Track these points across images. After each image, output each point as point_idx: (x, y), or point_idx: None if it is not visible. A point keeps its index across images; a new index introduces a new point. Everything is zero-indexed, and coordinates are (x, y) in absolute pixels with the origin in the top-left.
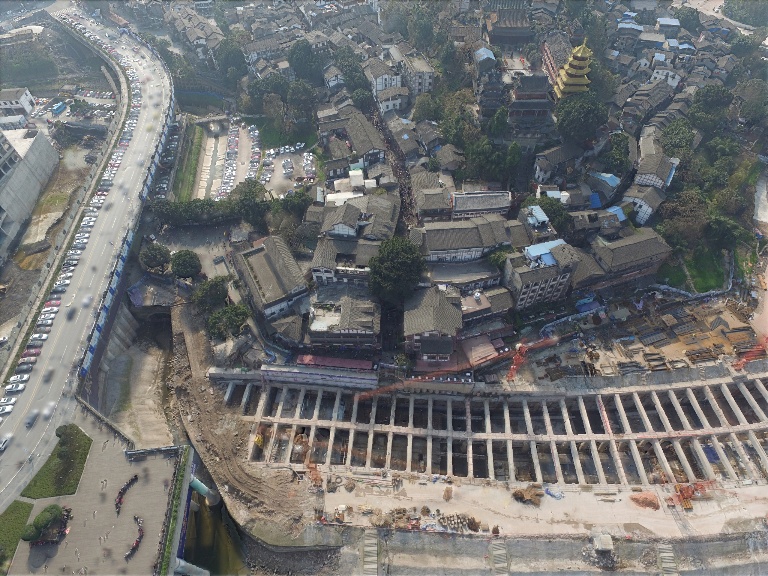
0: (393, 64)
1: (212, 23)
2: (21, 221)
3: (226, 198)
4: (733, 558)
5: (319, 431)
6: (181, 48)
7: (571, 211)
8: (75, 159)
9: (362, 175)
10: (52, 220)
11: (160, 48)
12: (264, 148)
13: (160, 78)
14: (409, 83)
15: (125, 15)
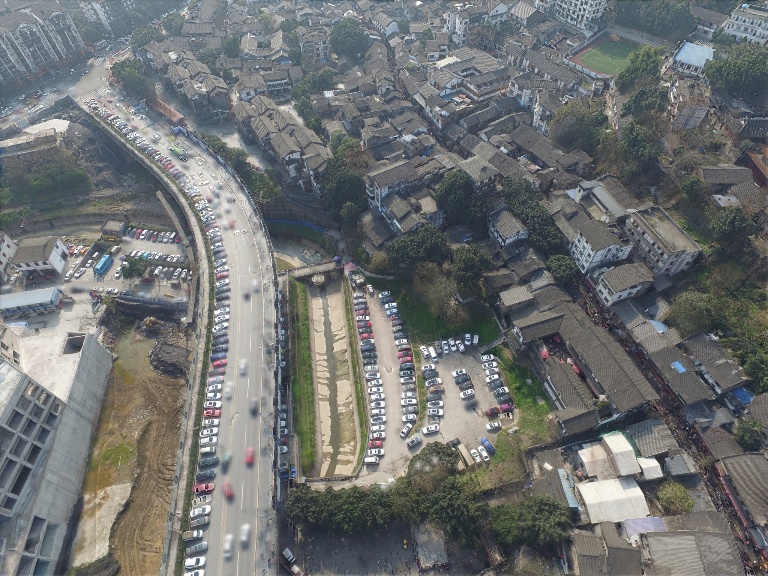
0: (610, 220)
1: (291, 112)
2: (68, 514)
3: (406, 486)
4: None
5: None
6: (260, 156)
7: None
8: (135, 360)
9: (633, 451)
10: (116, 504)
11: (235, 162)
12: (414, 339)
13: (245, 217)
14: (649, 258)
15: (176, 102)
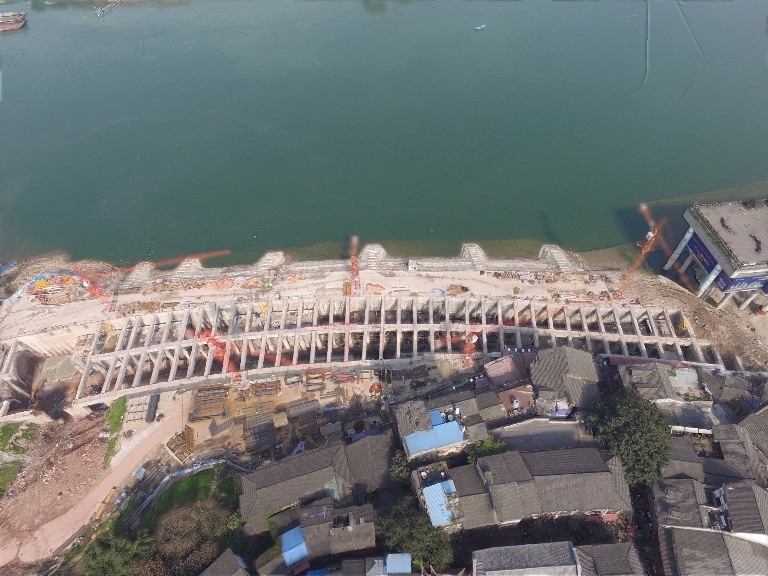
0: None
1: None
2: None
3: None
4: (330, 267)
5: (632, 347)
6: None
7: (365, 558)
8: None
9: None
10: None
11: None
12: None
13: None
14: None
15: None
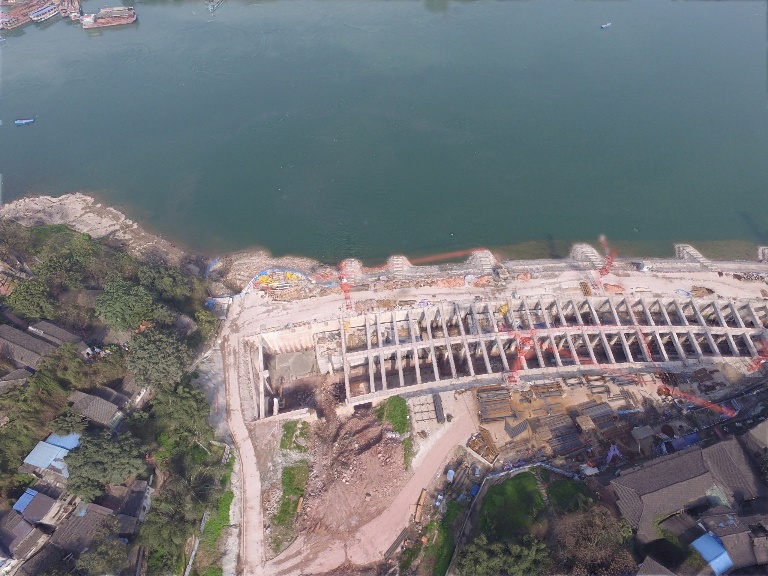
0: None
1: None
2: None
3: None
4: (553, 267)
5: None
6: None
7: None
8: None
9: None
10: None
11: None
12: None
13: None
14: None
15: None
